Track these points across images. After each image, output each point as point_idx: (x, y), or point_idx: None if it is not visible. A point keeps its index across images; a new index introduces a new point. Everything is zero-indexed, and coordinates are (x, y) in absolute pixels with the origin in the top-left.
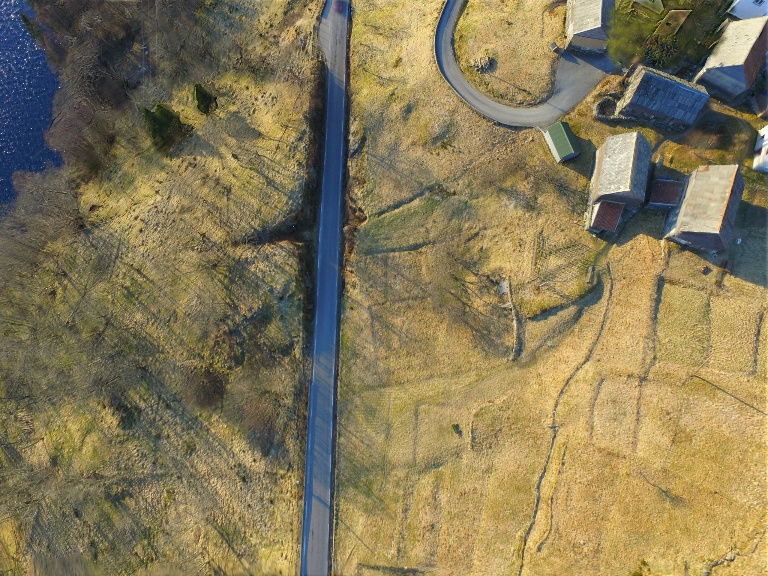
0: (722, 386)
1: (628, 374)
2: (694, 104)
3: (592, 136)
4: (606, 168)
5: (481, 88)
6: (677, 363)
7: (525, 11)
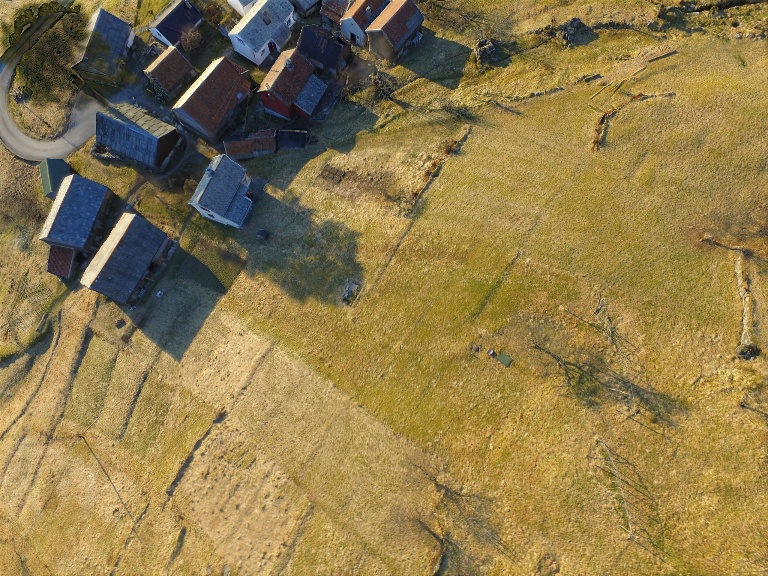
0: (94, 449)
1: (39, 431)
2: (147, 146)
3: (88, 174)
4: (51, 211)
5: (17, 119)
6: (74, 422)
7: (79, 40)
